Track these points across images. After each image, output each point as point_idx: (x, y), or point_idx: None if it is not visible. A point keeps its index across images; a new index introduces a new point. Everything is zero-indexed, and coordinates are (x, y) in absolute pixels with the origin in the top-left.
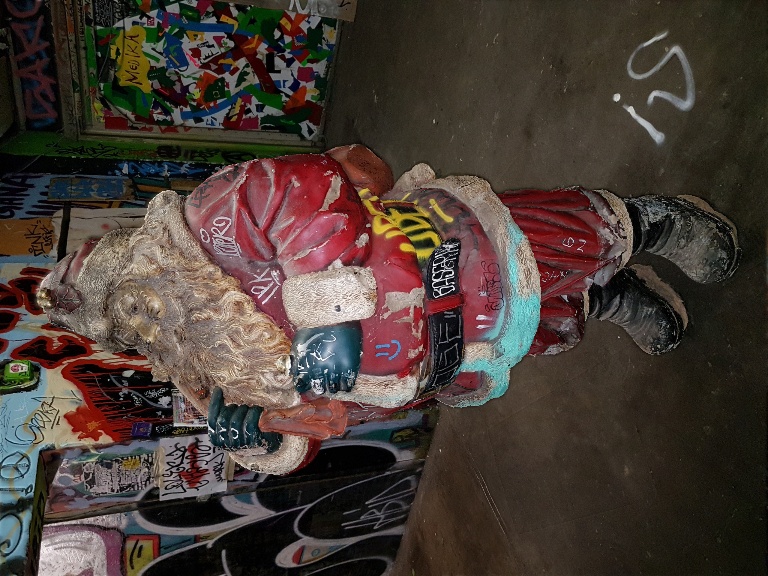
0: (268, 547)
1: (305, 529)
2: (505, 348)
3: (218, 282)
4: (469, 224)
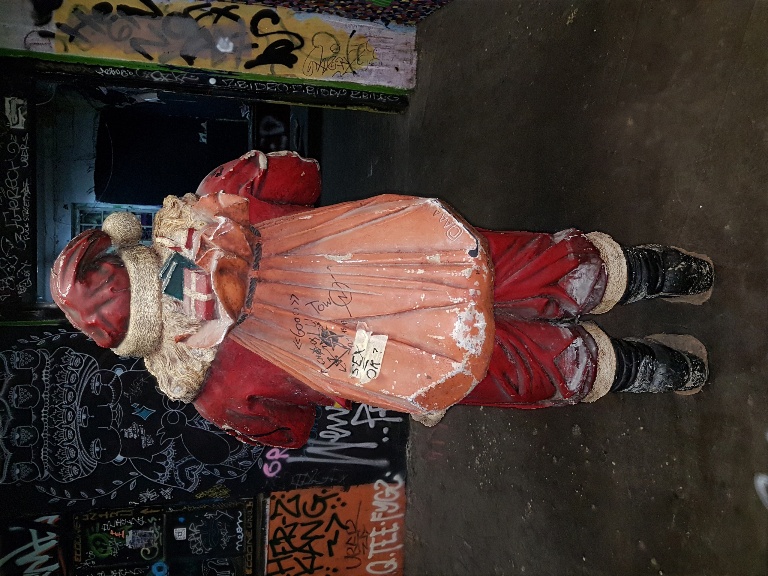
0: None
1: None
2: None
3: None
4: None
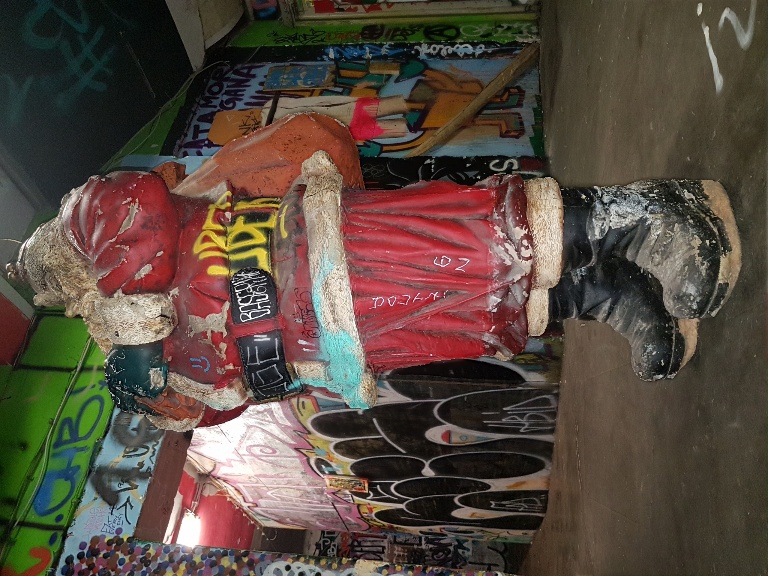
0: (414, 424)
1: (446, 418)
2: (333, 374)
3: (82, 283)
4: (296, 244)
